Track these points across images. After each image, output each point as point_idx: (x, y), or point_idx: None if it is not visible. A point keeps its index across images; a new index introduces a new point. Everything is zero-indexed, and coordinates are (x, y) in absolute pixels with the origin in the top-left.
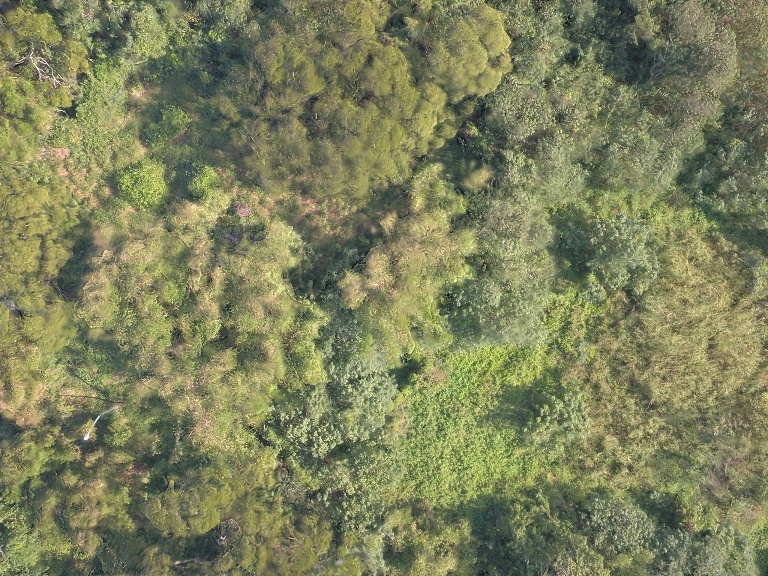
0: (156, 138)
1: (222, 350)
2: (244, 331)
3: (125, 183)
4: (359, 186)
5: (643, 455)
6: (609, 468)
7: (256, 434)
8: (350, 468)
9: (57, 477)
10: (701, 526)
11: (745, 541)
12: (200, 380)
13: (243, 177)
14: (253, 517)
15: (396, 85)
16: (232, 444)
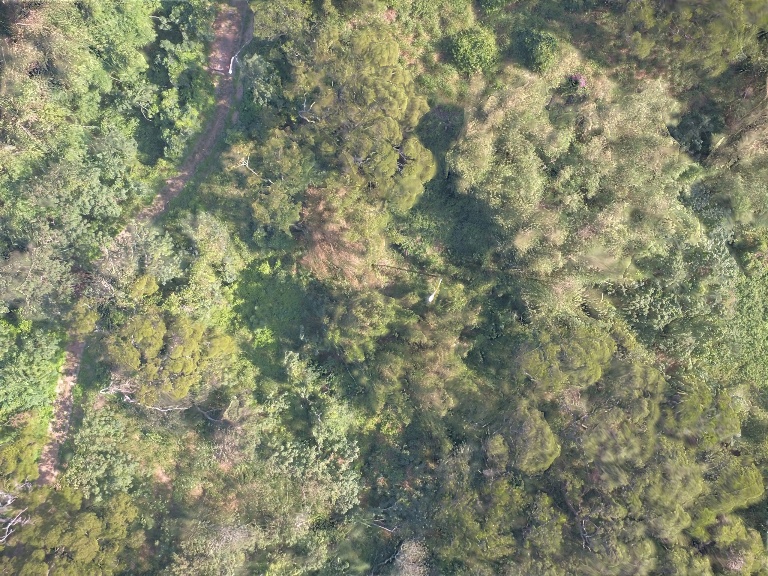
0: (495, 3)
1: (614, 200)
2: (624, 186)
3: (464, 47)
4: (731, 50)
5: None
6: None
7: (585, 308)
8: (695, 340)
9: (398, 339)
10: None
11: None
12: (573, 236)
13: (578, 48)
14: (640, 371)
15: None
16: (564, 316)
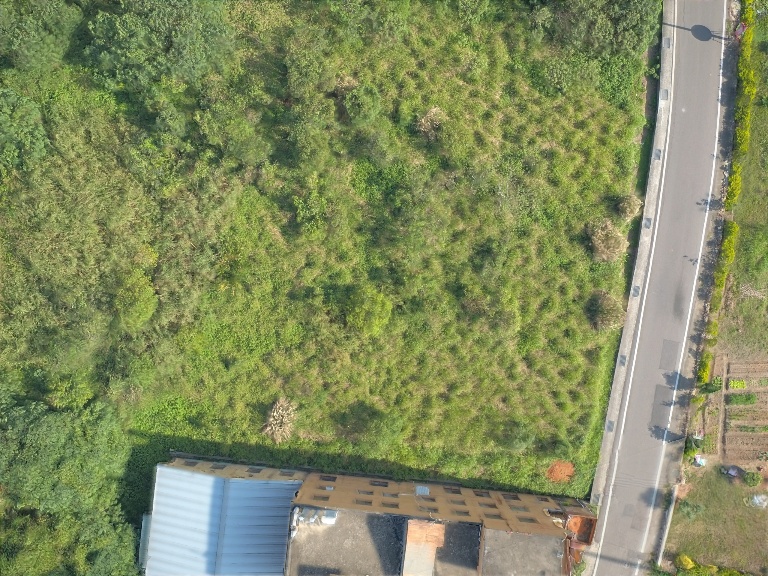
0: None
1: None
2: None
3: None
4: None
5: (27, 332)
6: (1, 346)
7: None
8: None
9: None
10: (66, 401)
11: (105, 416)
12: None
13: None
14: None
15: None
16: None
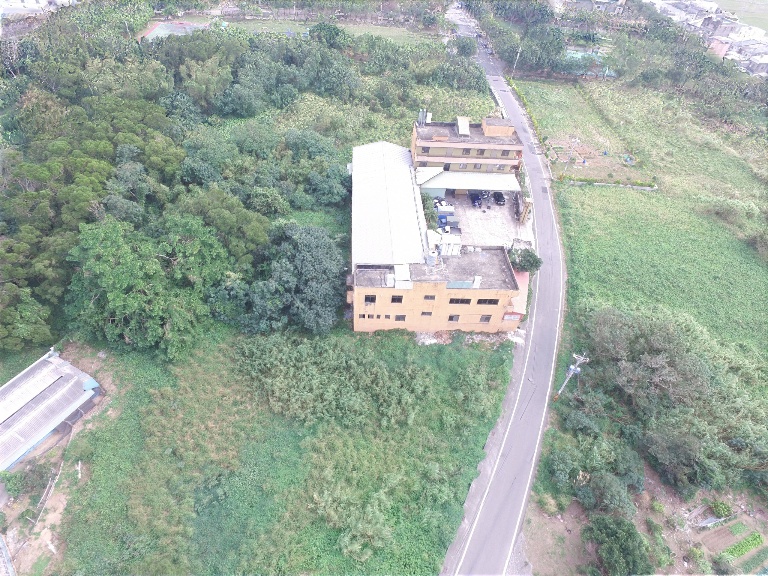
0: None
1: None
2: None
3: None
4: None
5: None
6: None
7: None
8: None
9: None
10: None
11: None
12: None
13: None
14: None
15: (209, 40)
16: None
